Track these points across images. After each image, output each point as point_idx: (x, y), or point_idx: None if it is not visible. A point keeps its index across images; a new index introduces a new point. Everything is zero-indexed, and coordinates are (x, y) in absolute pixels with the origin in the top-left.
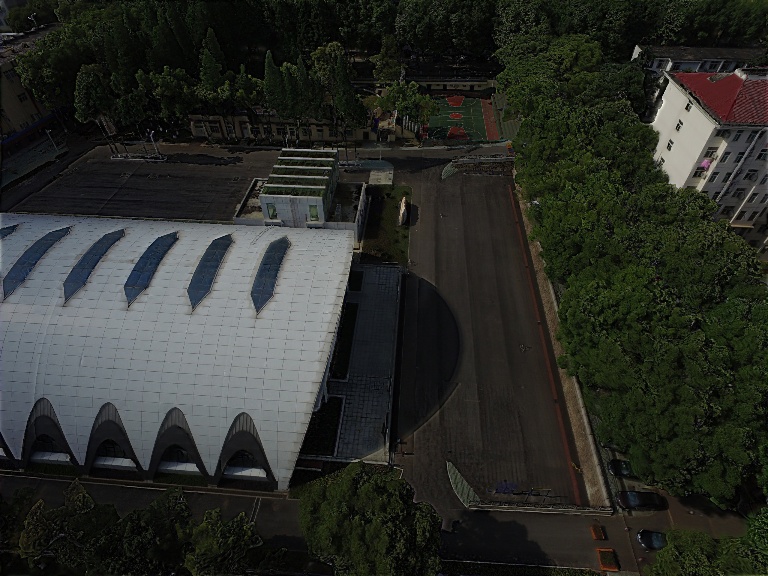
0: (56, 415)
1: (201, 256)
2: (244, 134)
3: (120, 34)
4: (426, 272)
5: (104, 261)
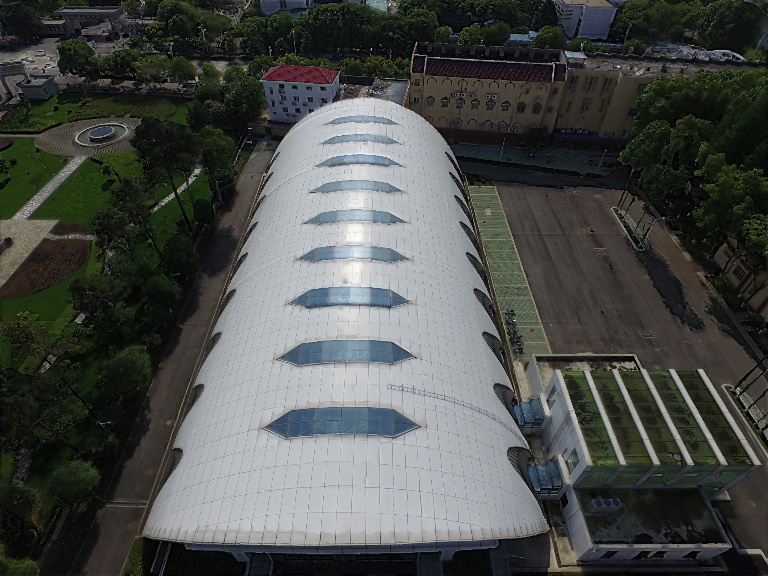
0: (226, 306)
1: (356, 338)
2: (763, 310)
3: (760, 106)
4: None
5: (344, 262)
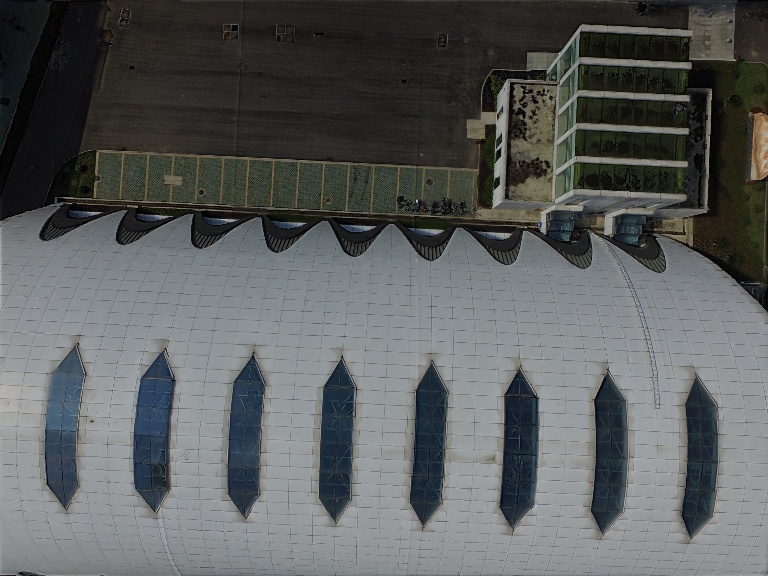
0: None
1: (593, 446)
2: None
3: None
4: None
5: (451, 461)
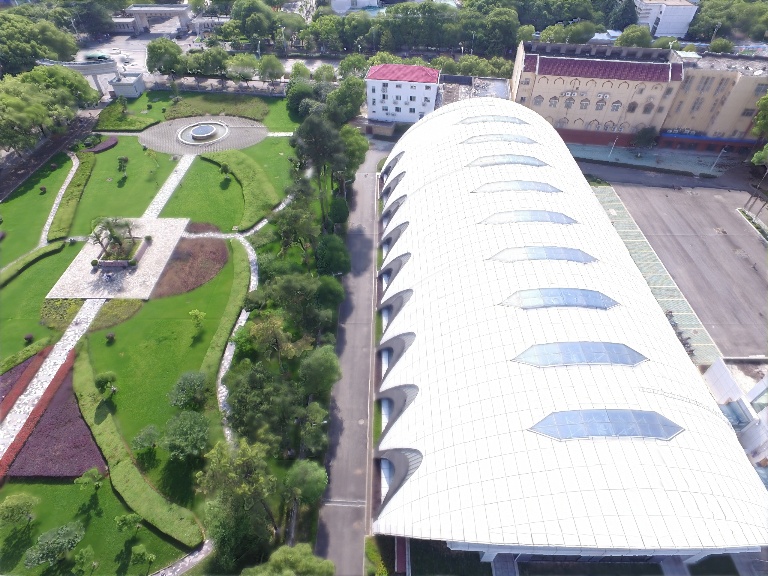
0: (404, 306)
1: (588, 340)
2: None
3: None
4: None
5: (542, 263)
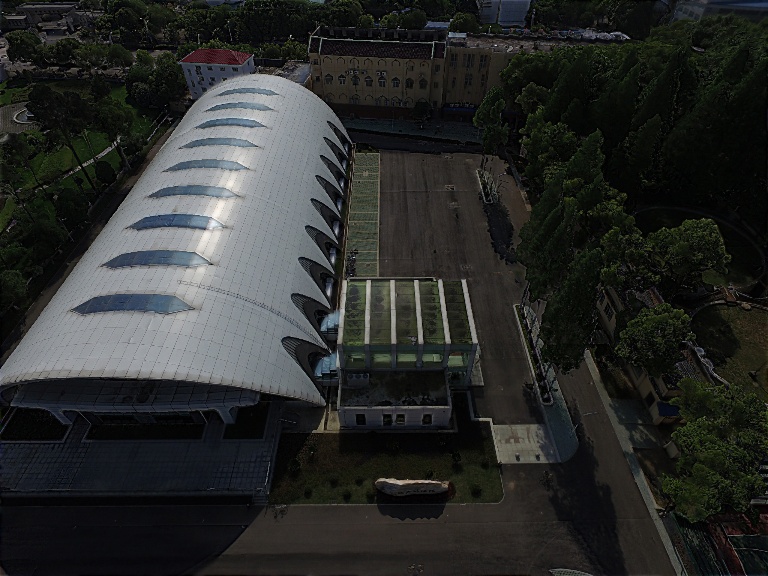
0: None
1: (165, 249)
2: None
3: (571, 70)
4: (256, 537)
5: (181, 197)
